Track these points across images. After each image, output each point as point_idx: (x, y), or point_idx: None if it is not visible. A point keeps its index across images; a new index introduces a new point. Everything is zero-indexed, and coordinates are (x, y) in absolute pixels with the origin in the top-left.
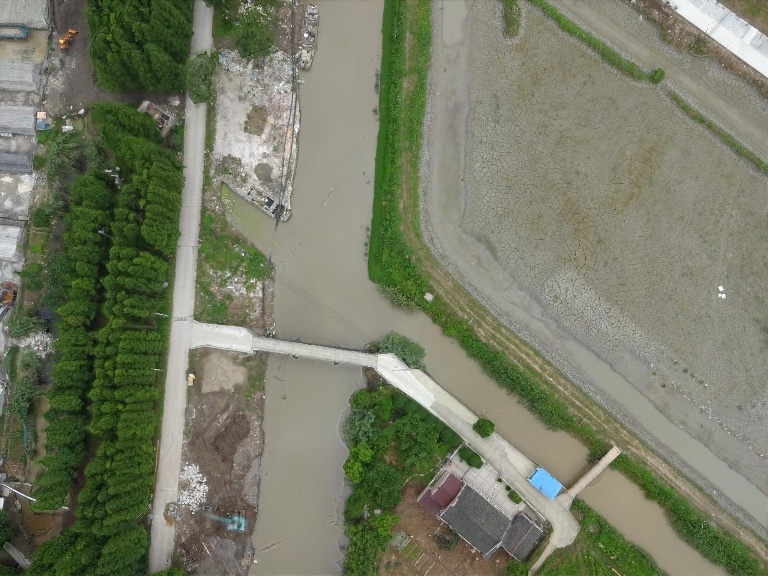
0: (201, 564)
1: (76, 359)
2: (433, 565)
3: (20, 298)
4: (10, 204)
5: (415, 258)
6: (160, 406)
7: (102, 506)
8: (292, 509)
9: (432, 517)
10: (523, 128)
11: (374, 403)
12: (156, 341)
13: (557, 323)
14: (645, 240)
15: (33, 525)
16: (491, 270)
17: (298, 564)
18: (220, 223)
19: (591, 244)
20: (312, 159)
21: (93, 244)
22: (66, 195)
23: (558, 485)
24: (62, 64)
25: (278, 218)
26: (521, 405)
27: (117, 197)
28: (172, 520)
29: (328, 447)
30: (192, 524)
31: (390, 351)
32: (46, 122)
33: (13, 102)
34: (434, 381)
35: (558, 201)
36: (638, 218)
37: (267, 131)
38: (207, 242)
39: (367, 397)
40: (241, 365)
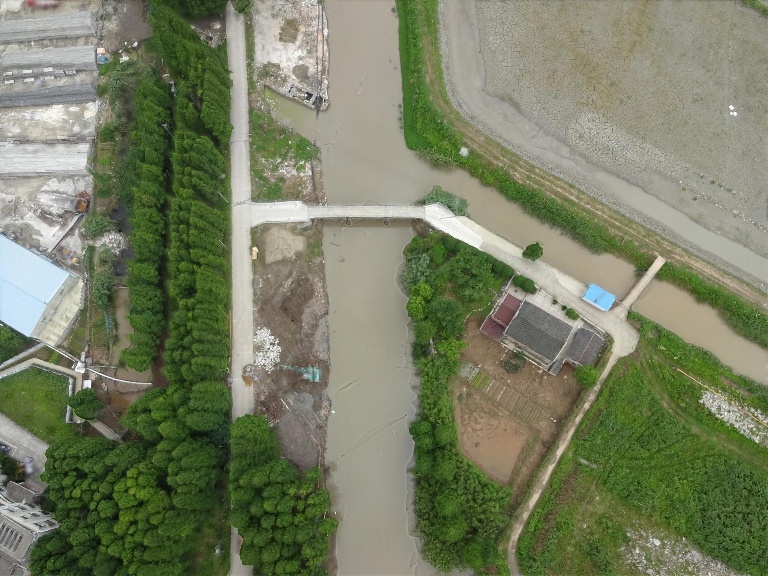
0: (282, 419)
1: (152, 233)
2: (504, 390)
3: (93, 204)
4: (78, 129)
5: (447, 121)
6: (229, 280)
7: (189, 350)
8: (362, 362)
9: (496, 345)
10: (527, 3)
11: (427, 248)
12: (221, 218)
13: (586, 159)
14: (654, 77)
15: (120, 404)
16: (517, 123)
17: (374, 414)
18: (266, 120)
19: (605, 88)
20: (342, 57)
21: (158, 136)
22: (127, 113)
23: (611, 297)
24: (115, 10)
25: (318, 108)
26: (564, 236)
27: (174, 103)
28: (250, 380)
29: (388, 305)
30: (269, 383)
31: (435, 201)
32: (105, 56)
33: (74, 46)
34: (480, 225)
35: (569, 57)
36: (644, 60)
37: (300, 38)
38: (257, 136)
39: (420, 239)
40: (299, 235)
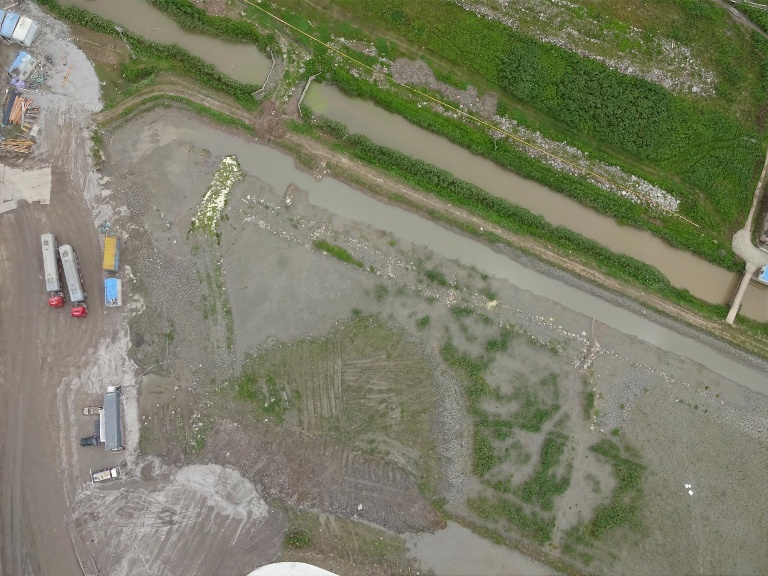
0: None
1: None
2: None
3: None
4: None
5: None
6: None
7: None
8: None
9: None
10: None
11: None
12: None
13: None
14: (764, 515)
15: None
16: None
17: None
18: None
19: None
20: None
21: None
22: None
23: (766, 278)
24: None
25: None
26: None
27: None
28: None
29: None
30: None
31: None
32: None
33: None
34: None
35: None
36: None
37: None
38: None
39: None
40: None
